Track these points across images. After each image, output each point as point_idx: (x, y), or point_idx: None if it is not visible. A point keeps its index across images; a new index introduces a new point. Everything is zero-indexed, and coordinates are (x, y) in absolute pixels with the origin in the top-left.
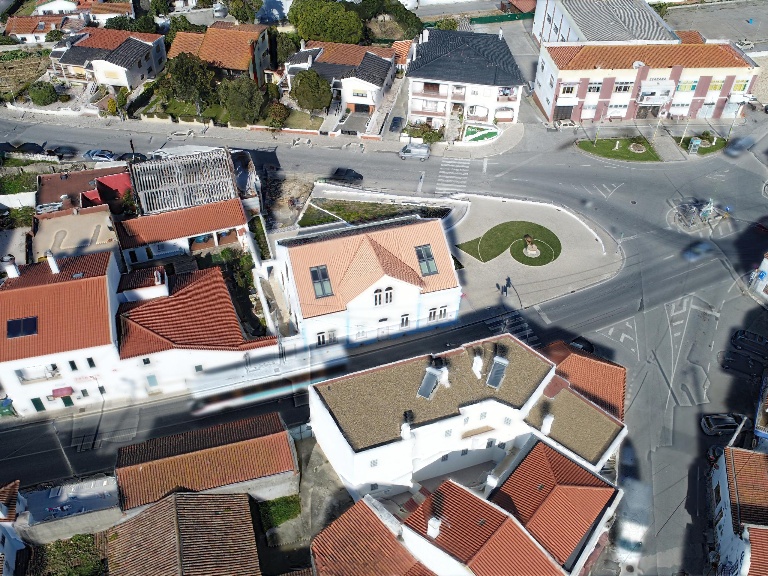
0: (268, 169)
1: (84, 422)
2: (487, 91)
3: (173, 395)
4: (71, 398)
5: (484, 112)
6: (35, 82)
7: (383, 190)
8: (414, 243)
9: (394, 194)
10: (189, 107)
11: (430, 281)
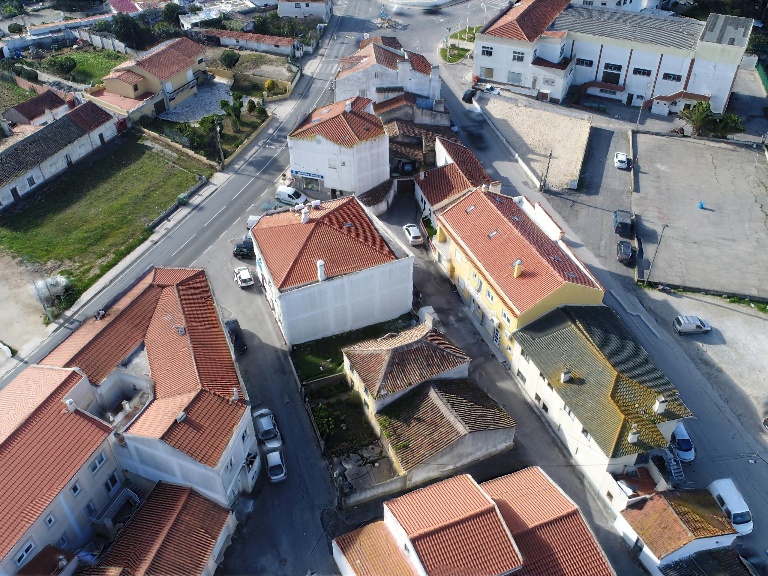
0: None
1: None
2: None
3: None
4: None
5: None
6: None
7: None
8: None
9: None
10: None
11: None
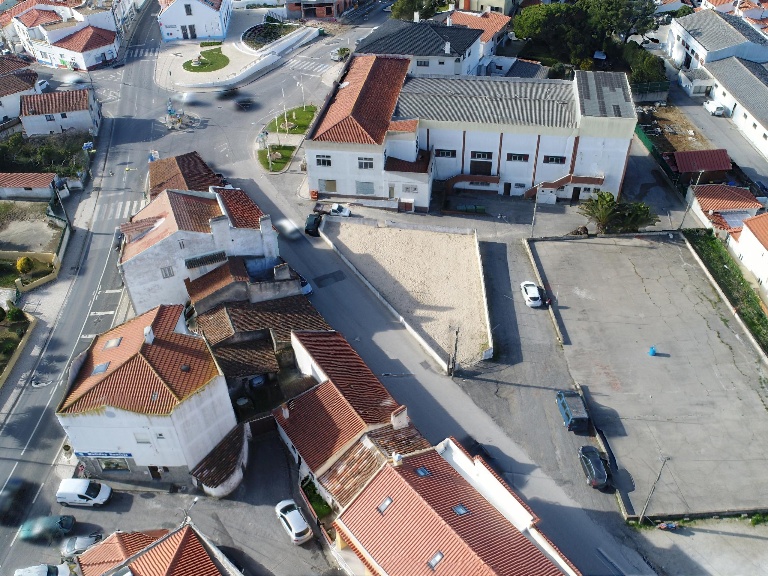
0: (356, 25)
1: None
2: None
3: None
4: None
5: None
6: None
7: (306, 47)
8: None
9: (299, 49)
10: None
11: None
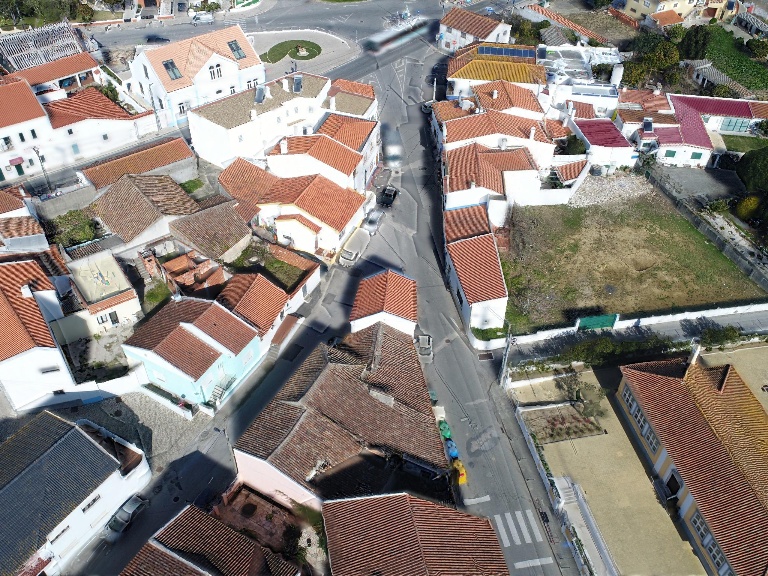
0: None
1: (37, 180)
2: None
3: (92, 158)
4: (22, 168)
5: None
6: None
7: None
8: (226, 40)
9: None
10: (4, 22)
11: (243, 62)
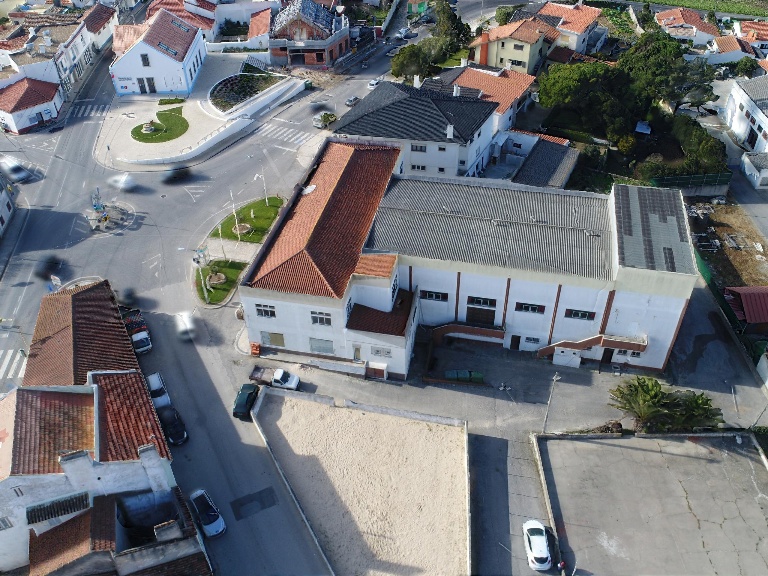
0: (352, 76)
1: None
2: None
3: None
4: None
5: None
6: None
7: (287, 106)
8: None
9: (278, 109)
10: (466, 56)
11: None
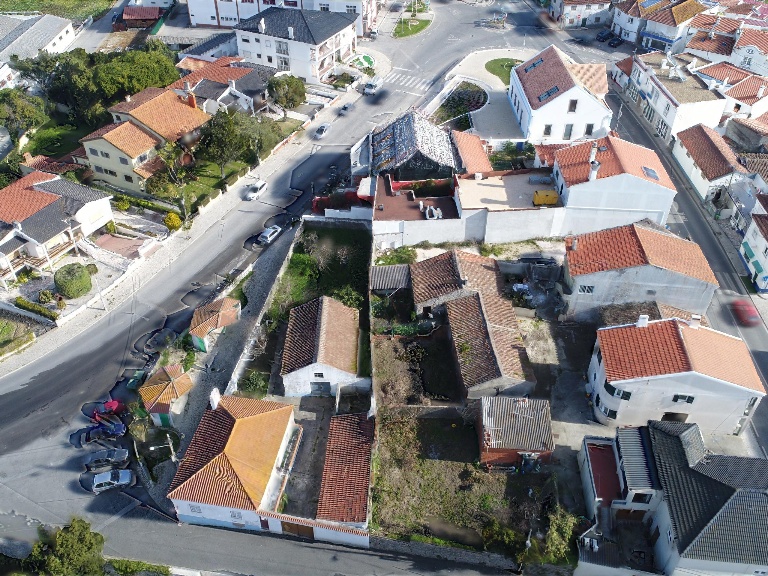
0: None
1: None
2: (348, 30)
3: None
4: None
5: (344, 50)
6: (58, 275)
7: None
8: None
9: (421, 104)
10: (199, 183)
11: None
